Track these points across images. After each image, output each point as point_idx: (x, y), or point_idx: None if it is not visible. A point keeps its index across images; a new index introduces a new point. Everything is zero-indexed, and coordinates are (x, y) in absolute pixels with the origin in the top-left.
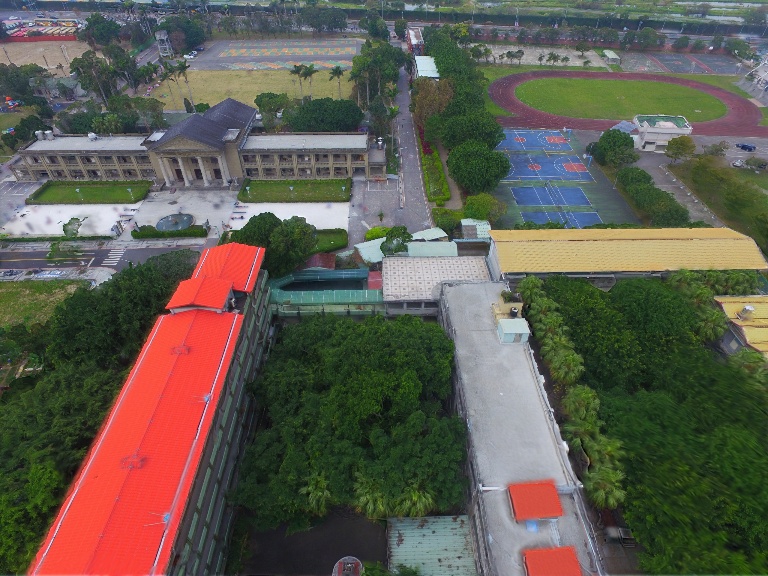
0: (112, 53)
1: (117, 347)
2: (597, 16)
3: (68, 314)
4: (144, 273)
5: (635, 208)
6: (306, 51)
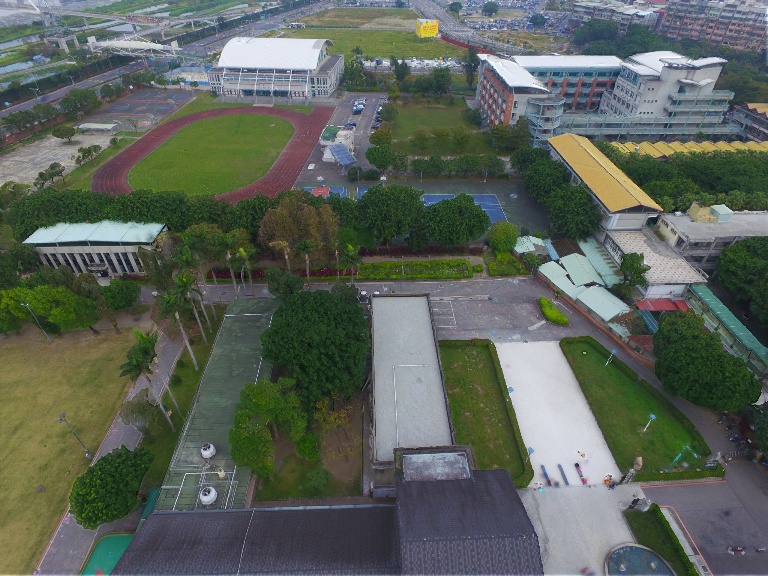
0: None
1: None
2: None
3: None
4: None
5: (452, 179)
6: None
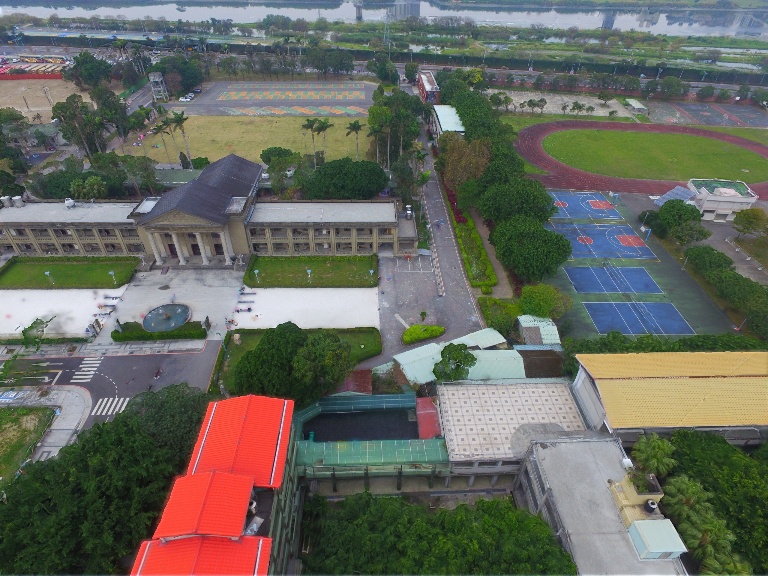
0: (100, 97)
1: (79, 564)
2: (608, 61)
3: (7, 516)
4: (123, 439)
5: (715, 297)
6: (312, 95)
